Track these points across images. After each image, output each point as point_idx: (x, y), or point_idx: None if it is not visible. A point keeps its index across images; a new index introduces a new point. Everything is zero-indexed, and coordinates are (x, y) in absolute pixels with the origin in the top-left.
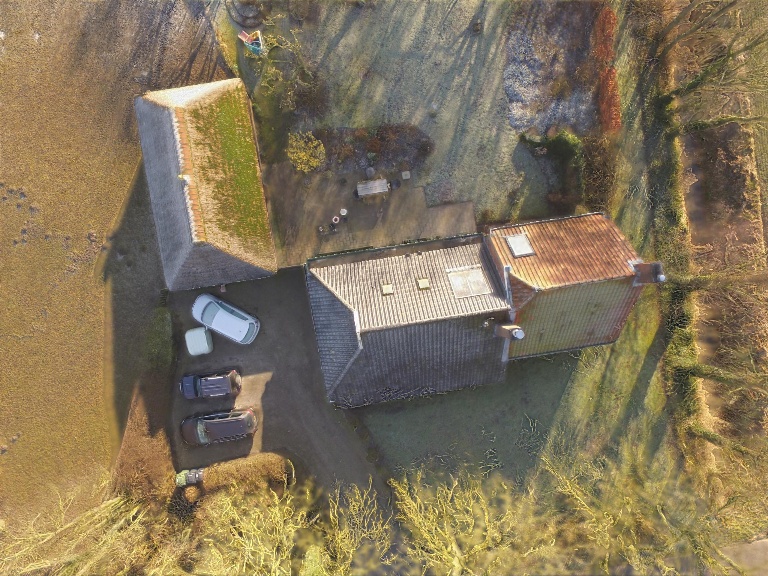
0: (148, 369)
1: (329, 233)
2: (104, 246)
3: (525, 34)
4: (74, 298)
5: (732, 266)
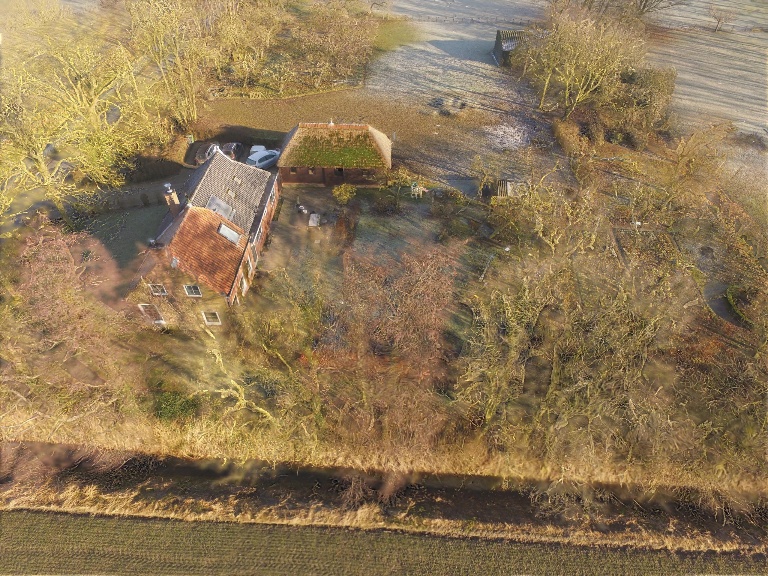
0: (253, 131)
1: None
2: None
3: None
4: None
5: (130, 295)
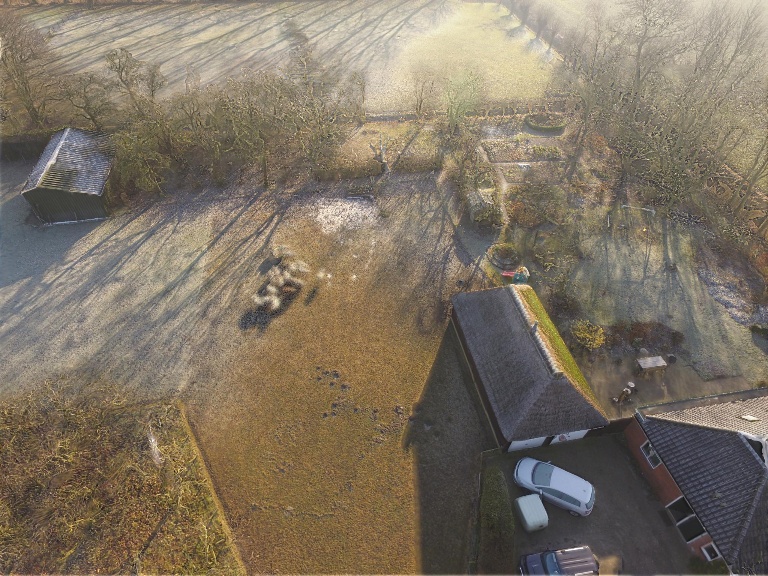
0: (490, 539)
1: (624, 404)
2: (412, 417)
3: (710, 271)
4: (381, 470)
5: None
